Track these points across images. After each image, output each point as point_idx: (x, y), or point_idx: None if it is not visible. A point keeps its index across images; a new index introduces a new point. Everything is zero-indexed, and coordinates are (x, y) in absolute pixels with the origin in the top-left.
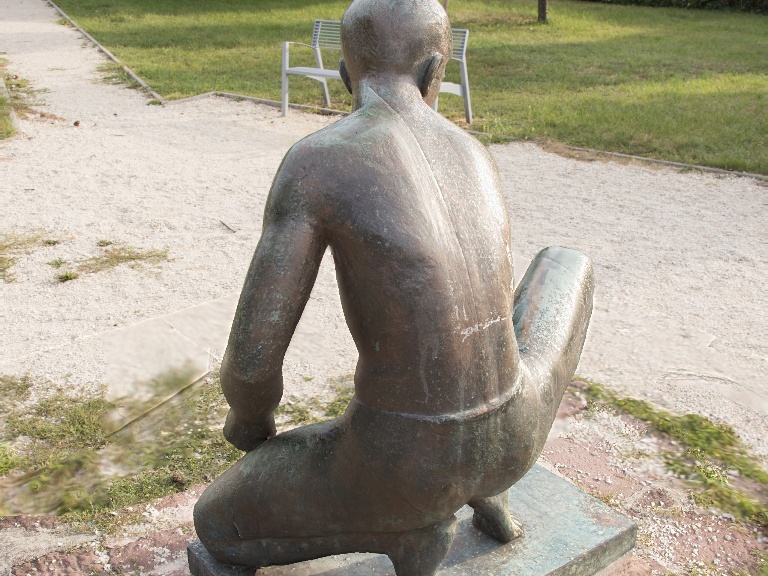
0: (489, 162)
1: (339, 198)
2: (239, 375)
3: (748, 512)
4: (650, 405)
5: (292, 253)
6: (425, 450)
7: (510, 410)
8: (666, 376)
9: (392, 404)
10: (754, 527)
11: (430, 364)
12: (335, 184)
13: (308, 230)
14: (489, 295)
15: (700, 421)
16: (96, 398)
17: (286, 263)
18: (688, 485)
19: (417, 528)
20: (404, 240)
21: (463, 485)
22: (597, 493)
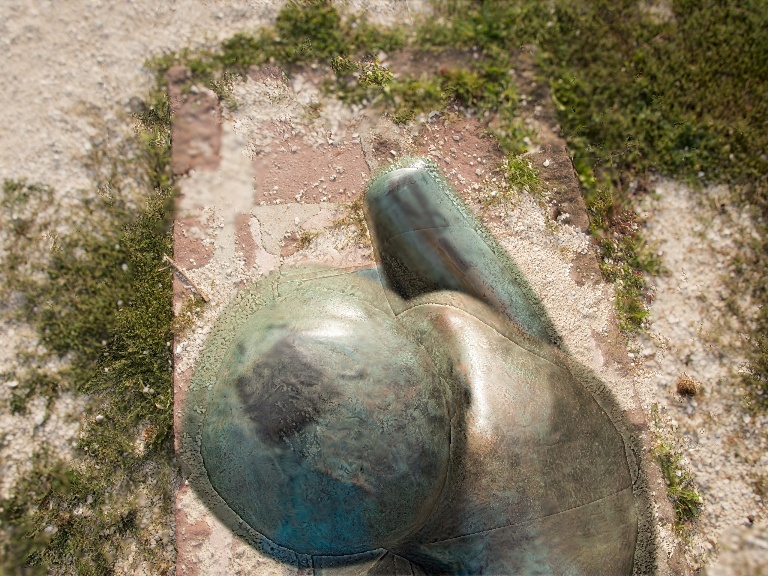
0: (543, 376)
1: None
2: None
3: (438, 96)
4: (246, 34)
5: None
6: None
7: None
8: None
9: None
10: (453, 106)
11: None
12: None
13: None
14: None
15: (301, 17)
16: None
17: None
18: (378, 108)
19: None
20: None
21: None
22: (354, 194)
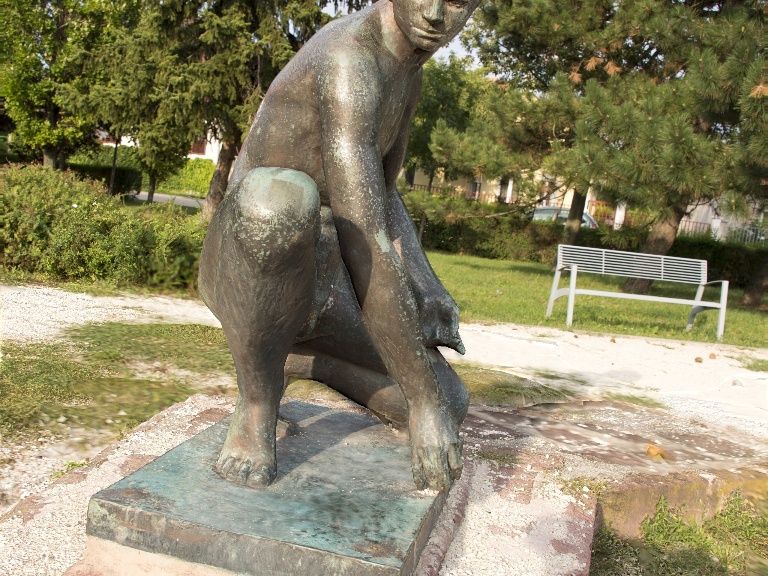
0: None
1: None
2: None
3: None
4: None
5: None
6: None
7: None
8: None
9: None
10: None
11: None
12: None
13: None
14: None
15: None
16: None
17: None
18: None
19: None
20: None
21: None
22: None
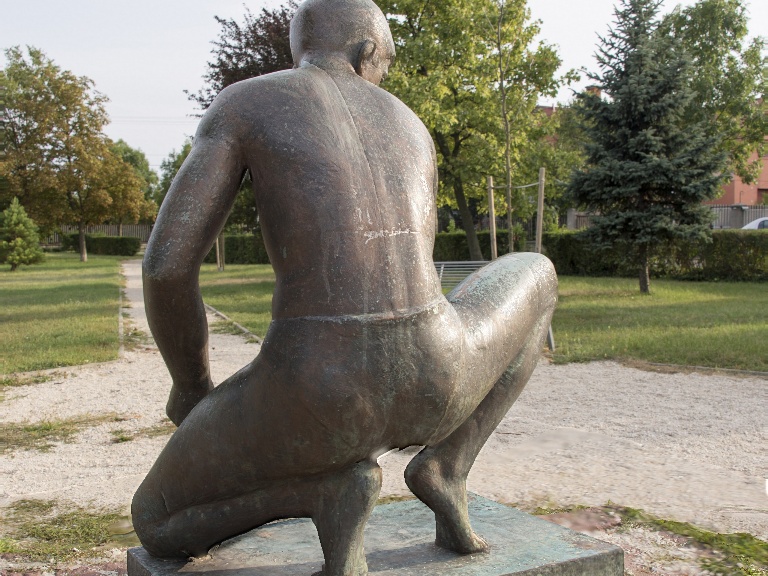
0: (411, 115)
1: (254, 117)
2: (148, 273)
3: None
4: None
5: (207, 163)
6: (327, 352)
7: (422, 325)
8: (720, 509)
9: (297, 309)
10: None
11: (332, 262)
12: (251, 106)
13: (225, 146)
14: (397, 207)
15: (750, 536)
16: (112, 513)
17: (200, 171)
18: None
19: (332, 466)
20: (308, 146)
21: (372, 400)
22: None
